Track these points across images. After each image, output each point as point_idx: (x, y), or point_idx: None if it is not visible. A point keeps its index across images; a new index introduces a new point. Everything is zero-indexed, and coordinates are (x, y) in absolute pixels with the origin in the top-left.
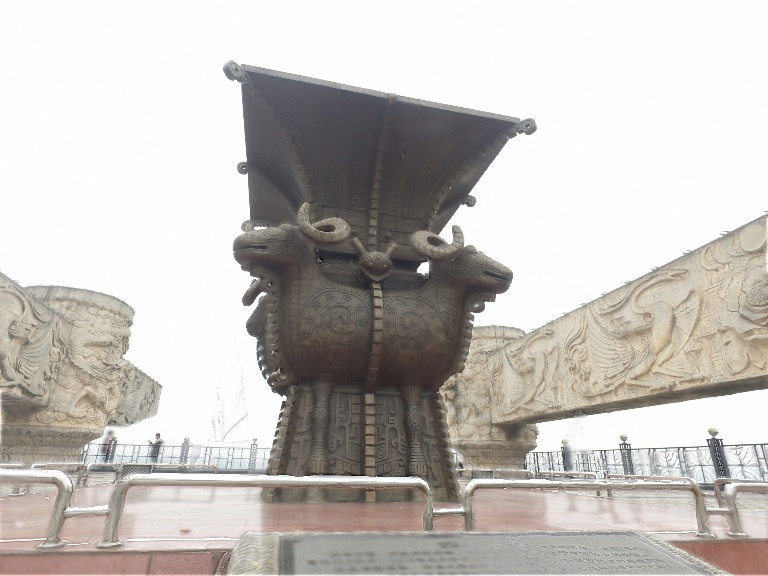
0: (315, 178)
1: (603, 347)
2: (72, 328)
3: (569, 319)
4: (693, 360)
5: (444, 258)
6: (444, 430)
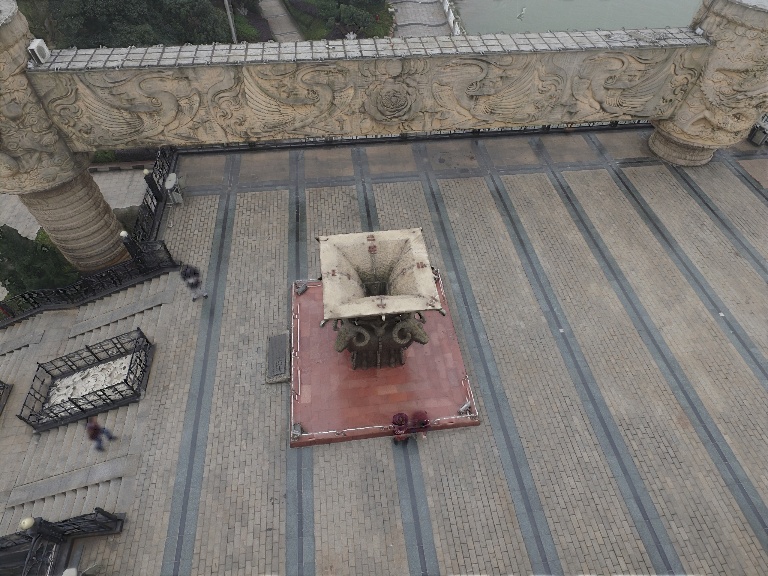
0: None
1: None
2: (714, 49)
3: None
4: None
5: None
6: None
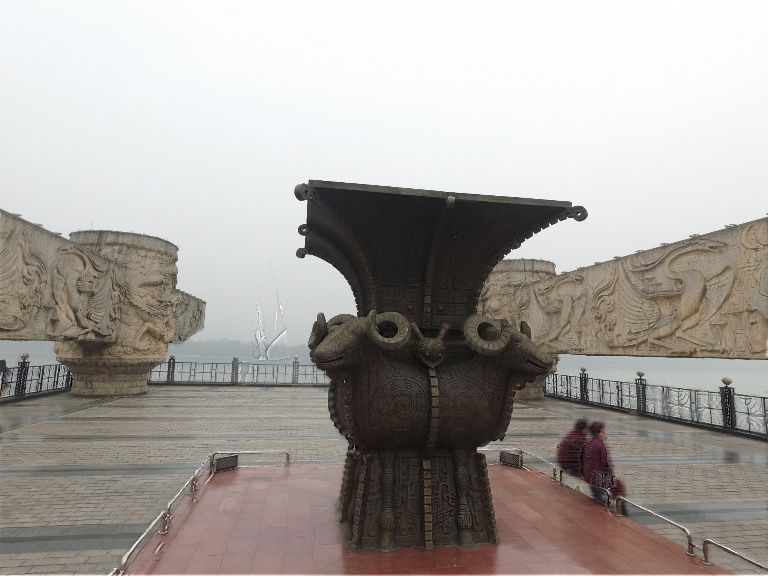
0: (374, 261)
1: (631, 303)
2: (126, 271)
3: (600, 269)
4: (717, 333)
5: (493, 354)
6: (486, 486)
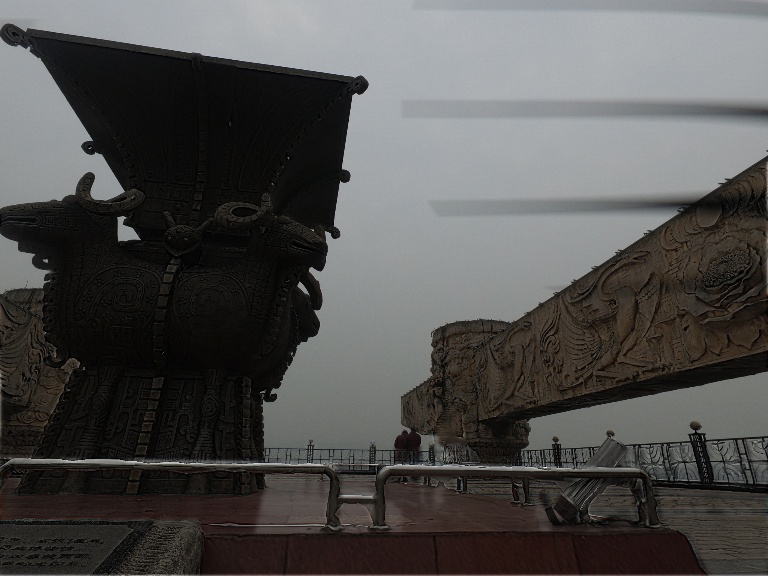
0: (135, 151)
1: (573, 337)
2: None
3: (544, 310)
4: (654, 348)
5: (241, 228)
6: (241, 416)
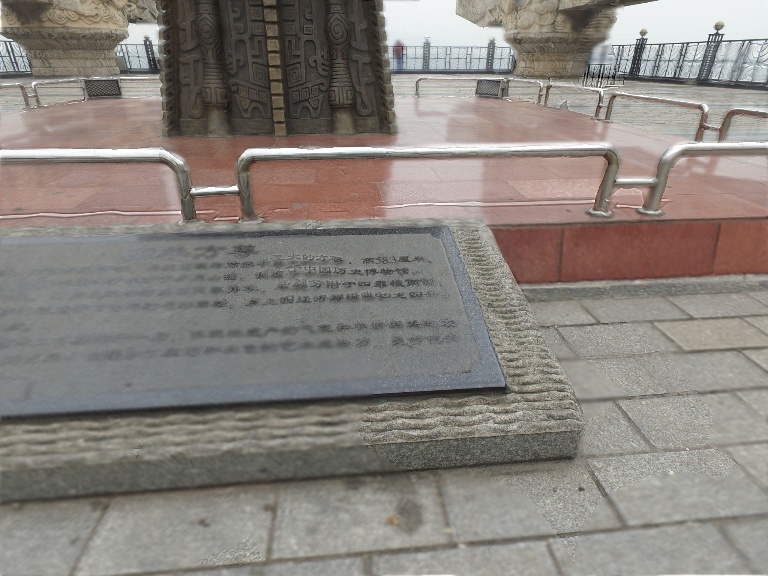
0: None
1: None
2: None
3: None
4: None
5: None
6: (378, 42)
